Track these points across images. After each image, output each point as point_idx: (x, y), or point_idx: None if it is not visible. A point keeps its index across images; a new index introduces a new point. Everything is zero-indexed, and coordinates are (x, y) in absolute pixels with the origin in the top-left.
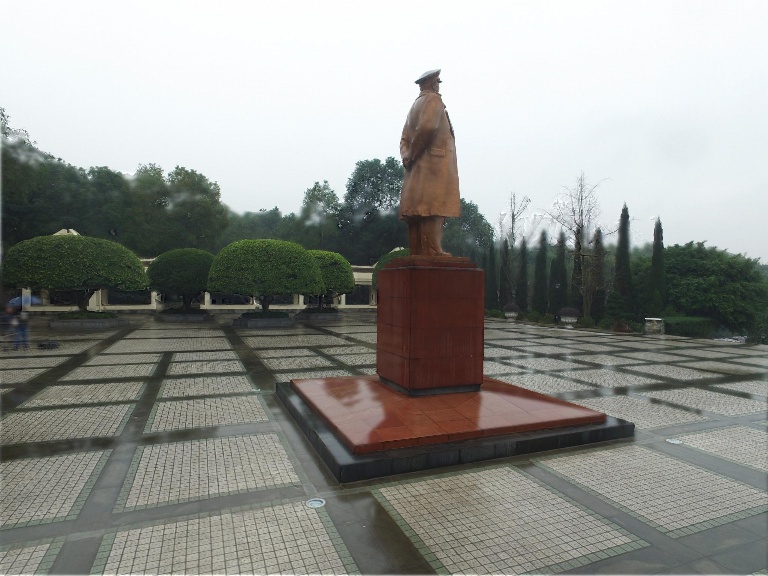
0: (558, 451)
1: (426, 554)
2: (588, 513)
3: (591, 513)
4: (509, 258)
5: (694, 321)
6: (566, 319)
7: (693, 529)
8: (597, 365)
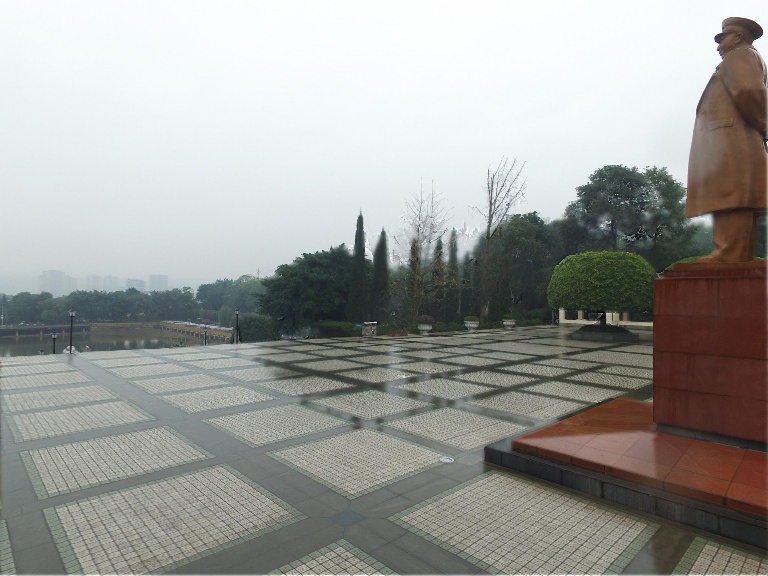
0: None
1: None
2: None
3: None
4: None
5: None
6: None
7: None
8: (281, 401)
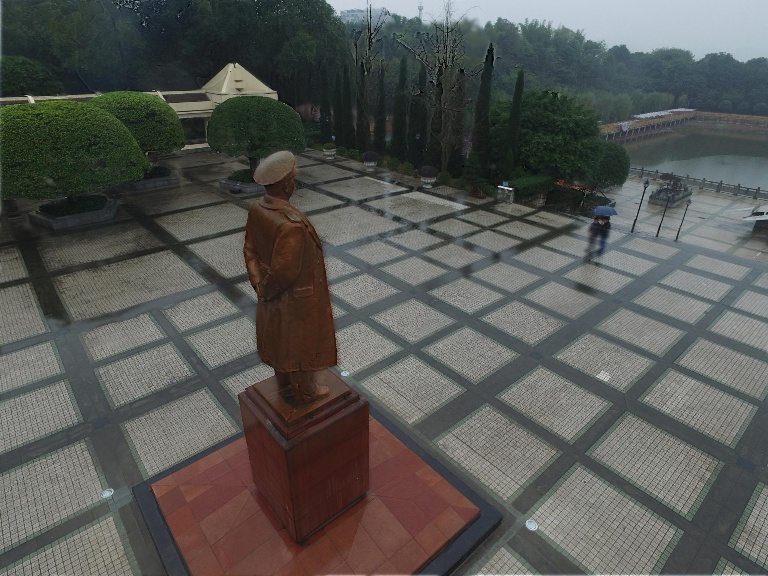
0: None
1: None
2: None
3: None
4: (366, 90)
5: (538, 183)
6: (426, 179)
7: None
8: (461, 316)
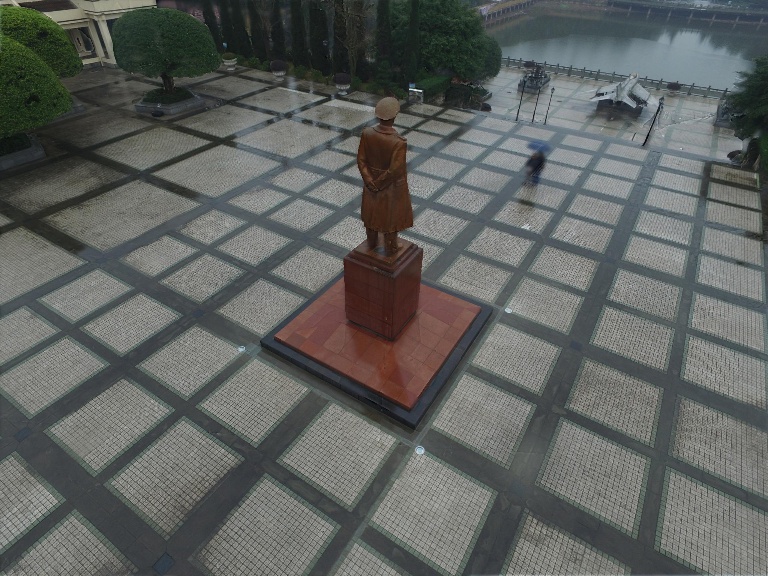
0: (473, 347)
1: (483, 455)
2: (511, 396)
3: (512, 395)
4: None
5: (440, 83)
6: (341, 87)
7: (543, 387)
8: (420, 201)
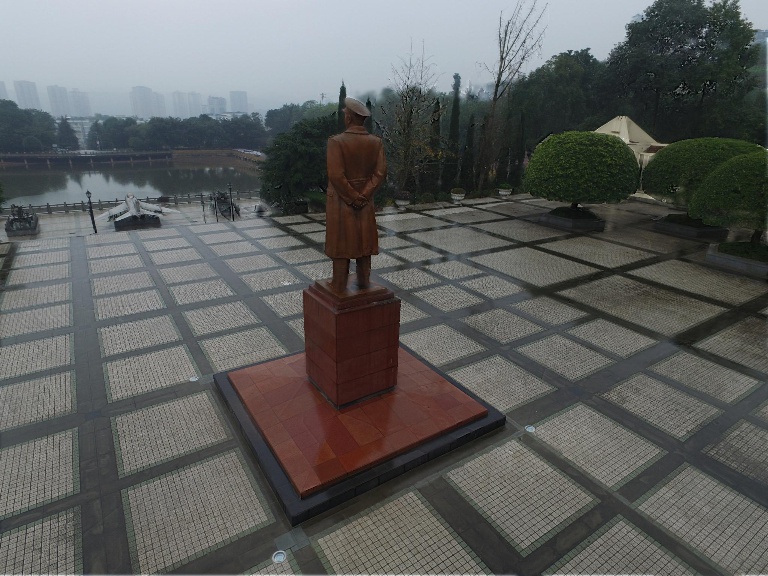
0: None
1: None
2: None
3: (483, 360)
4: None
5: None
6: None
7: None
8: (164, 311)
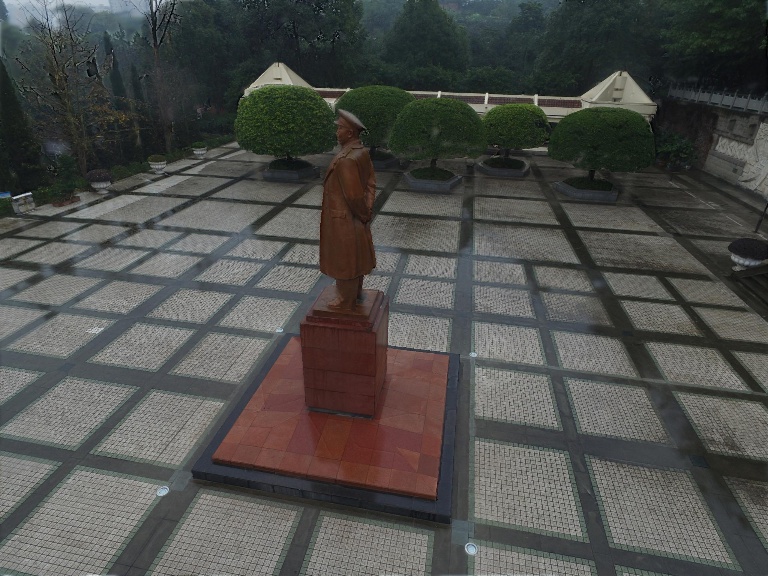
0: None
1: None
2: None
3: None
4: None
5: None
6: None
7: None
8: None
